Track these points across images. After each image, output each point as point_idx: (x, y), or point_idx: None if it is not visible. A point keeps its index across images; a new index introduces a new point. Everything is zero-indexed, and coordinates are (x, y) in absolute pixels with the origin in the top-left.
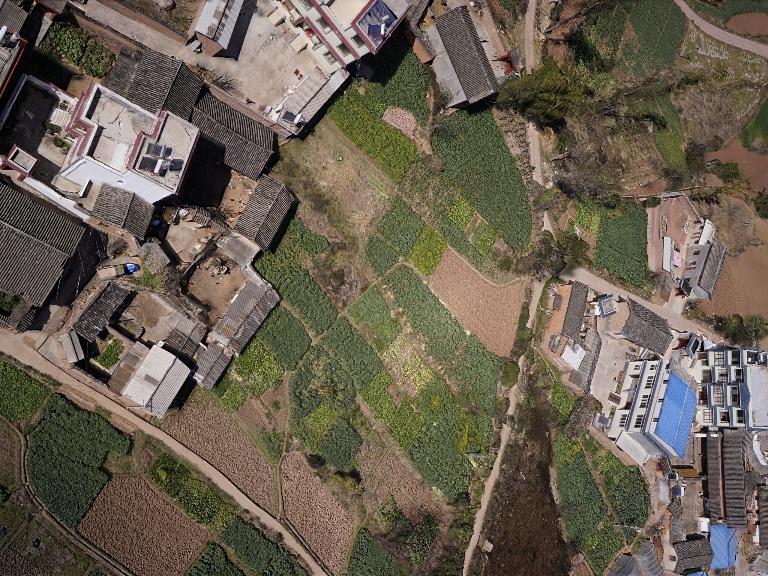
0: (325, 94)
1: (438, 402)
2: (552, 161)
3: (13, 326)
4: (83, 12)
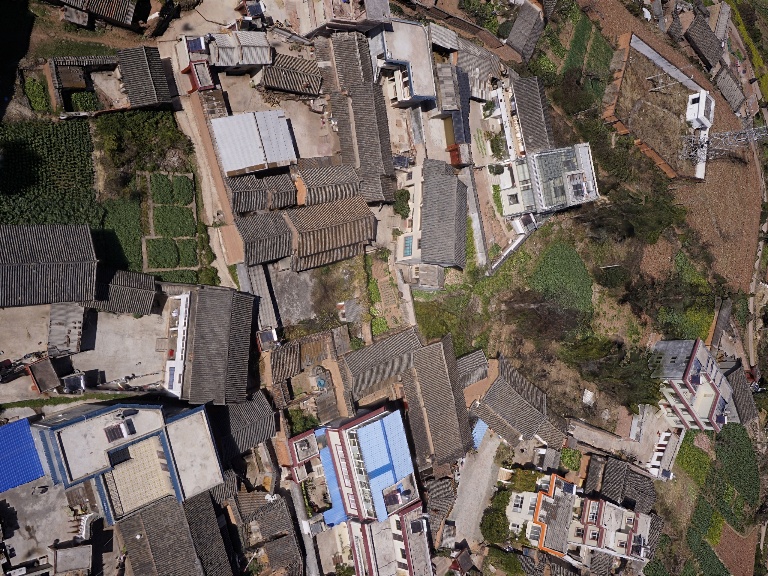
0: (677, 449)
1: None
2: (765, 429)
3: None
4: (573, 435)
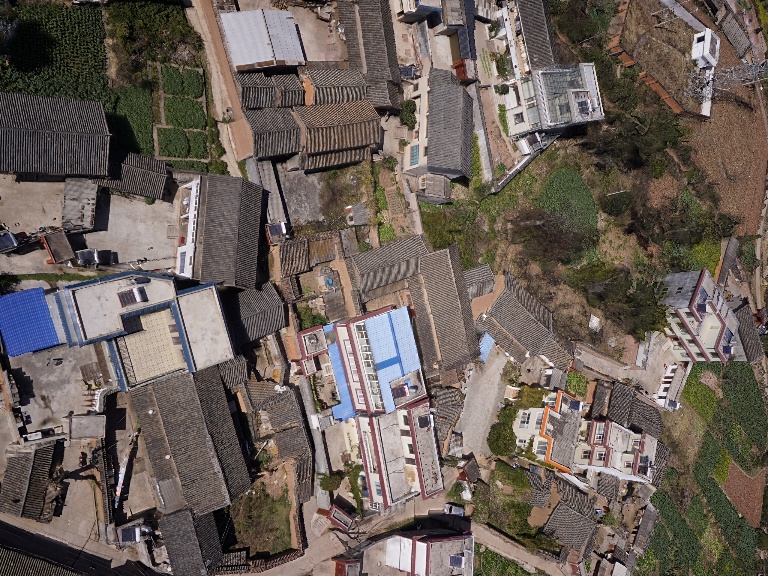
0: (684, 381)
1: (729, 567)
2: None
3: (563, 563)
4: None
